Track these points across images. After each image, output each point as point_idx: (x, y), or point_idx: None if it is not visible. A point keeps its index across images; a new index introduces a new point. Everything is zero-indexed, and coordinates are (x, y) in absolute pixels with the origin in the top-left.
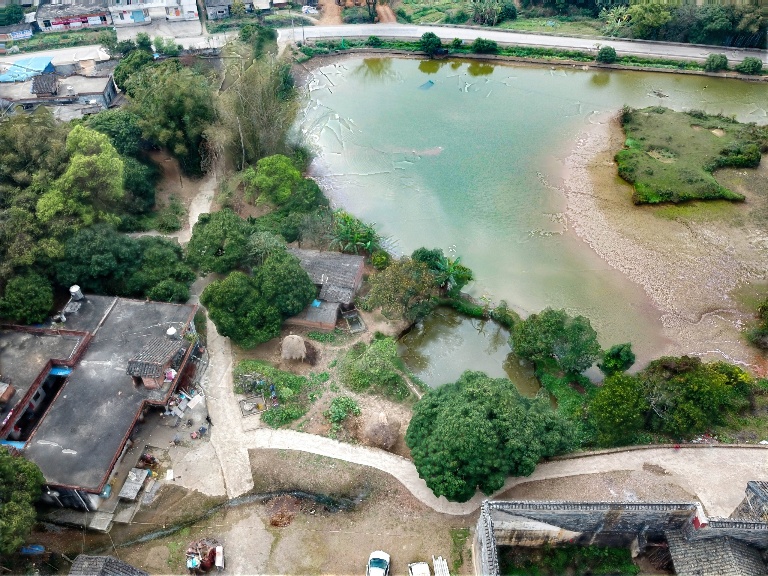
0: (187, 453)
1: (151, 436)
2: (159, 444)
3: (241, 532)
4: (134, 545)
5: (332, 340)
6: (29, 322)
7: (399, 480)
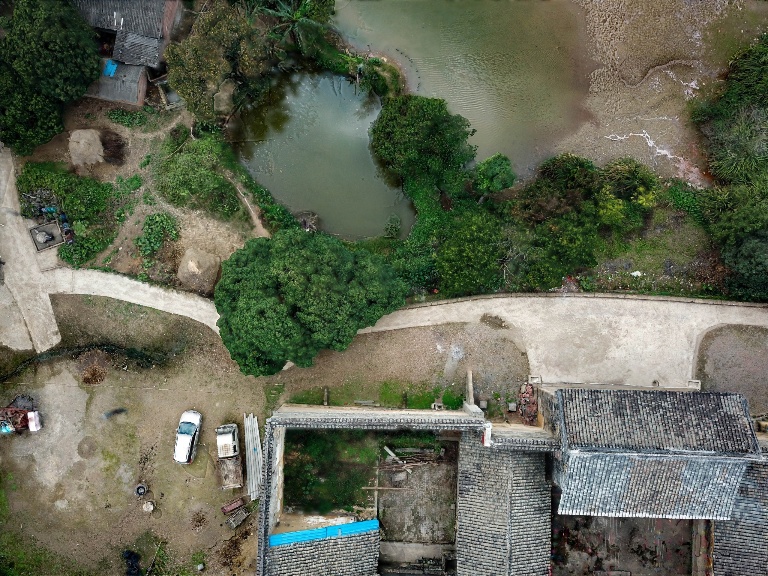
0: None
1: None
2: None
3: (54, 389)
4: None
5: (142, 123)
6: None
7: (215, 332)
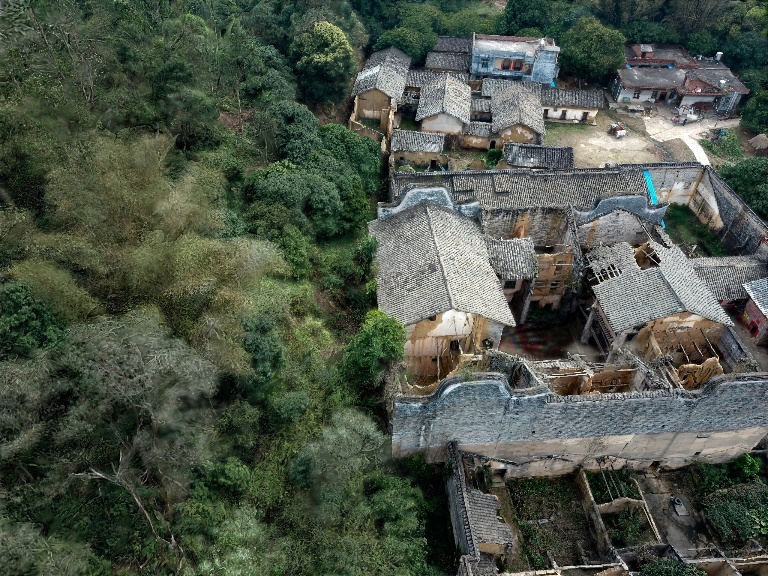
0: (662, 120)
1: (662, 108)
2: (660, 111)
3: (636, 141)
4: (610, 116)
5: None
6: (689, 52)
7: None
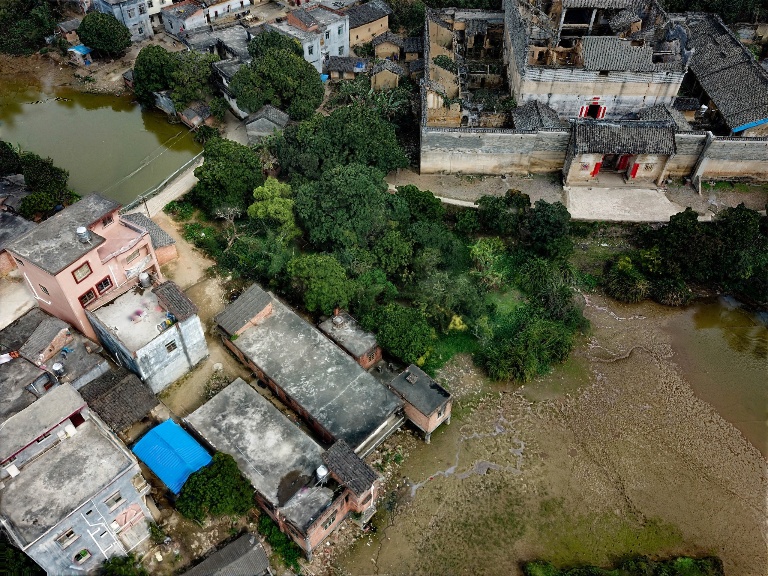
0: None
1: None
2: None
3: None
4: None
5: None
6: None
7: None
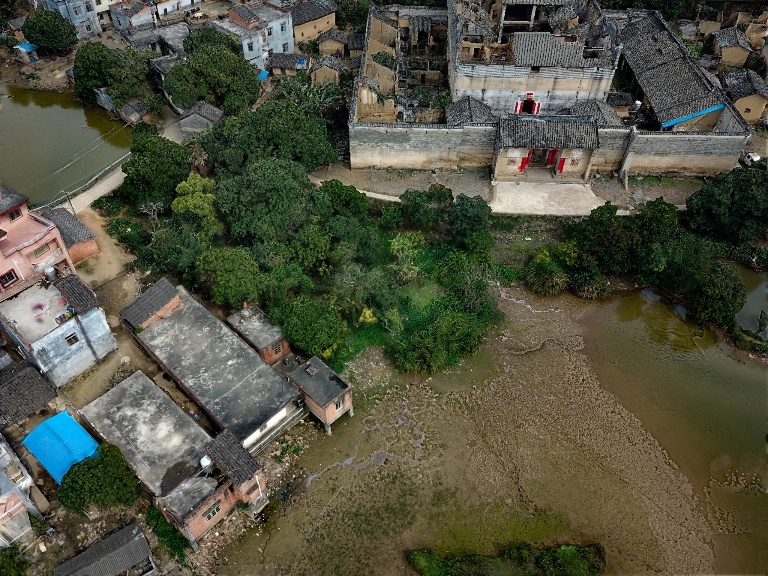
0: None
1: None
2: None
3: None
4: None
5: None
6: None
7: None
